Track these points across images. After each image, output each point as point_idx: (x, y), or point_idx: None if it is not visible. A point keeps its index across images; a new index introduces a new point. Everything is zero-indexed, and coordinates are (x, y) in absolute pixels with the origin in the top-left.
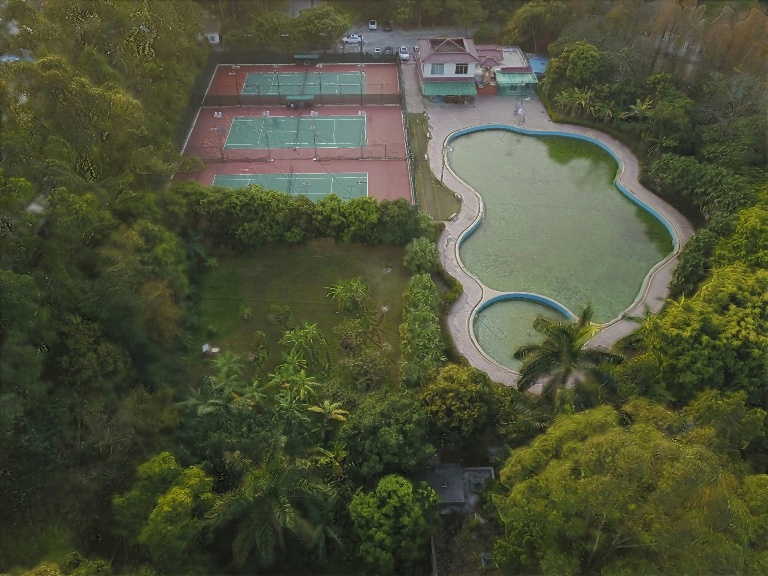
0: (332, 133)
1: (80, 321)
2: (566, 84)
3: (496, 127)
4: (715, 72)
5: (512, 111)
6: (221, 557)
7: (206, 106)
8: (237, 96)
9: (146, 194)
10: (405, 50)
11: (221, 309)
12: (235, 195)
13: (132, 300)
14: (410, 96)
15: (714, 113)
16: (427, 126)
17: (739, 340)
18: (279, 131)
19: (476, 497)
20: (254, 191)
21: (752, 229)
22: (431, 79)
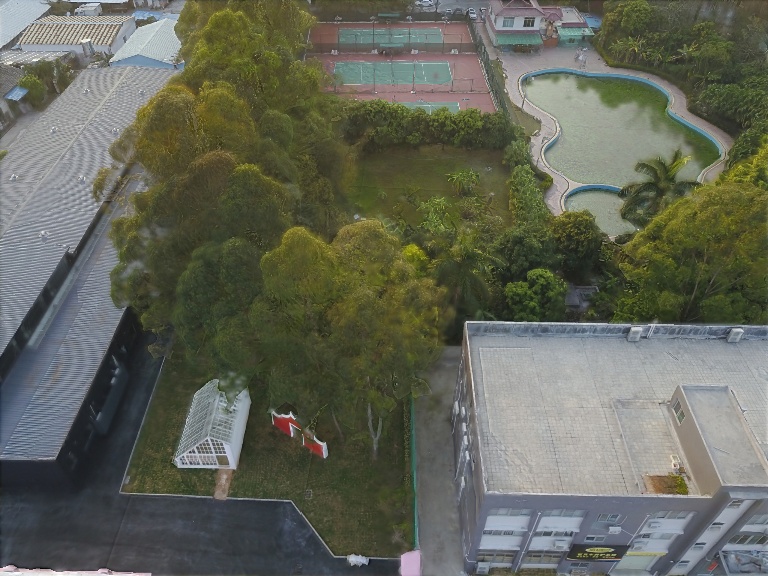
0: (422, 73)
1: (308, 158)
2: (620, 35)
3: (560, 71)
4: (753, 16)
5: (573, 58)
6: None
7: (310, 53)
8: (337, 44)
9: (309, 96)
10: (473, 11)
11: (361, 193)
12: (369, 105)
13: (342, 146)
14: (483, 47)
15: (751, 52)
16: (502, 69)
17: None
18: (377, 72)
19: (587, 302)
20: (384, 101)
21: None
22: (502, 31)
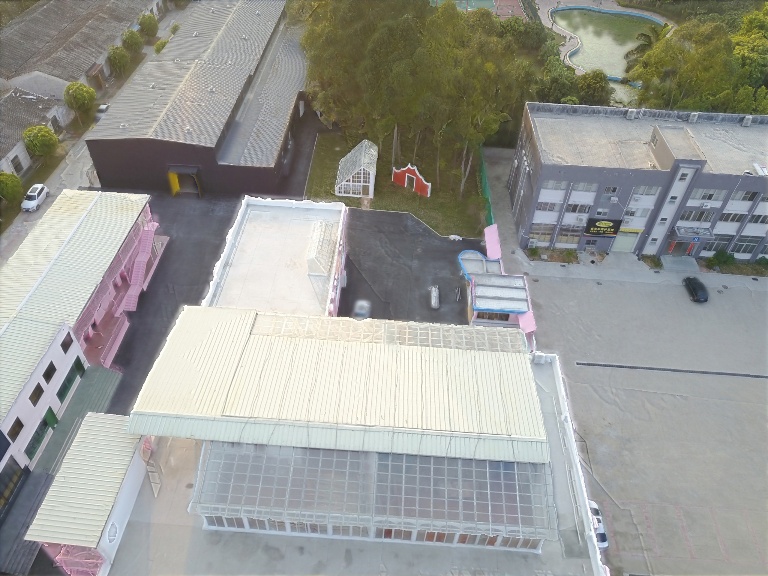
0: (472, 3)
1: None
2: None
3: (581, 8)
4: None
5: None
6: None
7: None
8: None
9: None
10: None
11: None
12: None
13: None
14: None
15: None
16: (535, 4)
17: (740, 55)
18: None
19: None
20: None
21: (750, 19)
22: None
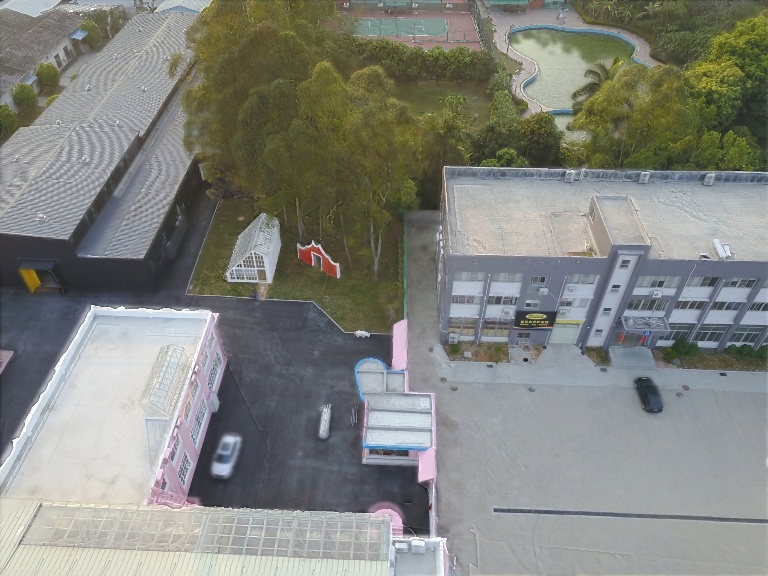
0: (422, 27)
1: None
2: None
3: (543, 27)
4: None
5: (555, 17)
6: (413, 180)
7: None
8: None
9: None
10: None
11: None
12: (375, 42)
13: None
14: None
15: (706, 6)
16: (492, 25)
17: (706, 89)
18: (383, 26)
19: None
20: None
21: (720, 43)
22: None
